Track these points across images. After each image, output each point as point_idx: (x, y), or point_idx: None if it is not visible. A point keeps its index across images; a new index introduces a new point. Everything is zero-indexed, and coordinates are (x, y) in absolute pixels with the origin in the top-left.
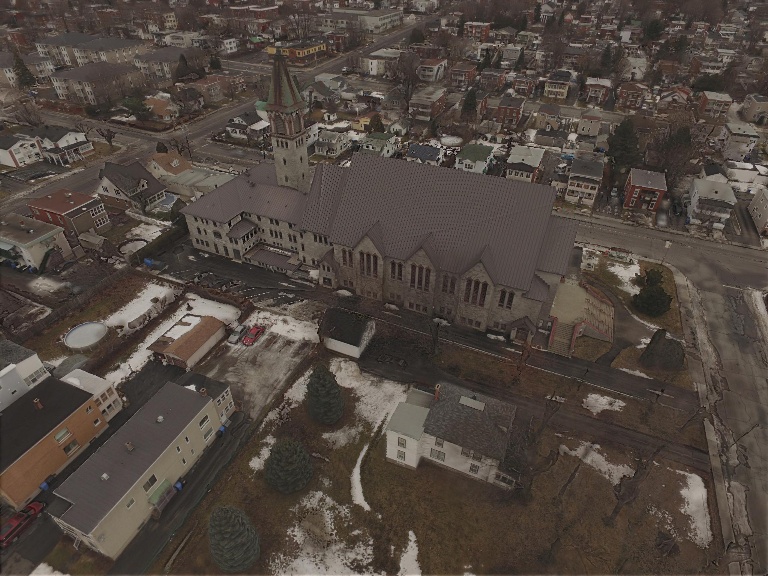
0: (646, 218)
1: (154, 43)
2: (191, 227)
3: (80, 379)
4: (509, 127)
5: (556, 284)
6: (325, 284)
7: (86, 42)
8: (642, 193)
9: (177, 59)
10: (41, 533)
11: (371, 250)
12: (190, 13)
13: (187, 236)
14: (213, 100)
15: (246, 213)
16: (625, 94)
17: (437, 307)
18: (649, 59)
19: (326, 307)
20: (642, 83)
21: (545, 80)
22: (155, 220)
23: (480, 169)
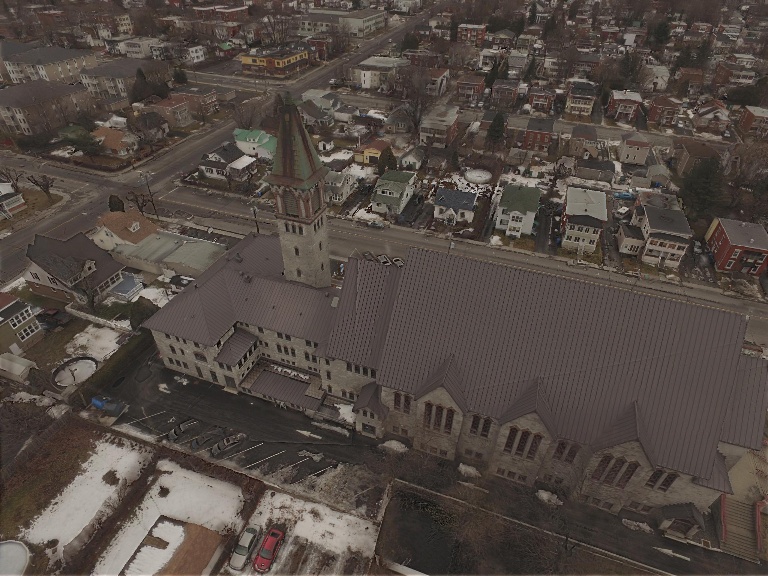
0: (750, 286)
1: (106, 51)
2: (161, 344)
3: None
4: (541, 155)
5: (738, 456)
6: (365, 431)
7: (21, 53)
8: (744, 254)
9: (133, 74)
10: None
11: (445, 402)
12: (147, 15)
13: (155, 346)
14: (180, 125)
15: (241, 322)
16: (659, 110)
17: (540, 474)
18: (668, 66)
19: (373, 478)
20: (668, 95)
21: (562, 93)
22: (108, 322)
23: (530, 221)
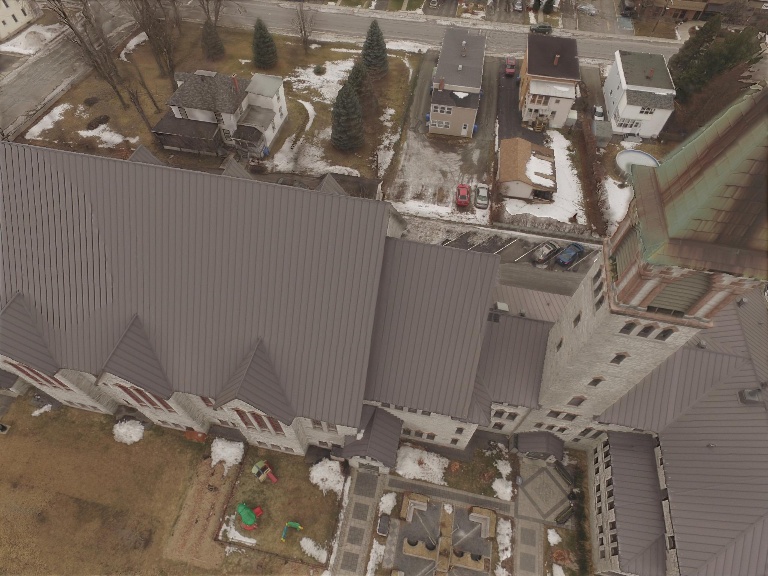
0: None
1: None
2: None
3: (560, 91)
4: None
5: None
6: None
7: None
8: None
9: None
10: (495, 69)
11: None
12: None
13: None
14: None
15: None
16: None
17: None
18: None
19: None
20: None
21: None
22: None
23: None
